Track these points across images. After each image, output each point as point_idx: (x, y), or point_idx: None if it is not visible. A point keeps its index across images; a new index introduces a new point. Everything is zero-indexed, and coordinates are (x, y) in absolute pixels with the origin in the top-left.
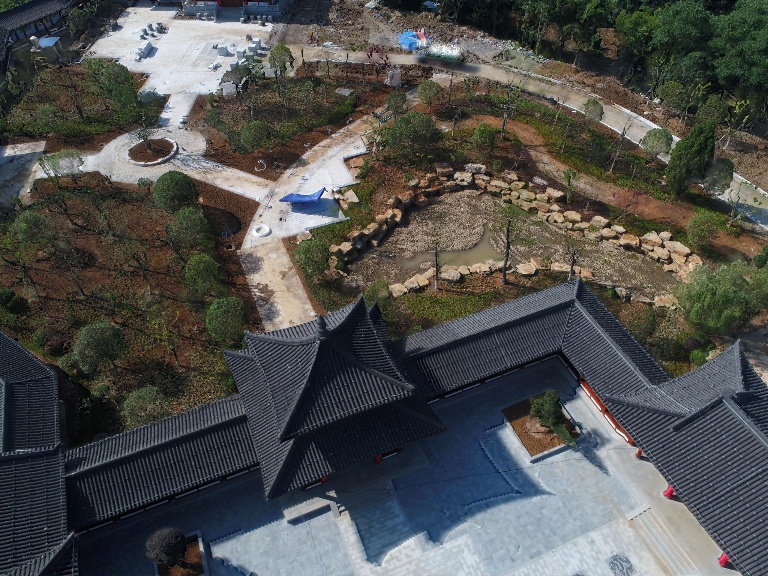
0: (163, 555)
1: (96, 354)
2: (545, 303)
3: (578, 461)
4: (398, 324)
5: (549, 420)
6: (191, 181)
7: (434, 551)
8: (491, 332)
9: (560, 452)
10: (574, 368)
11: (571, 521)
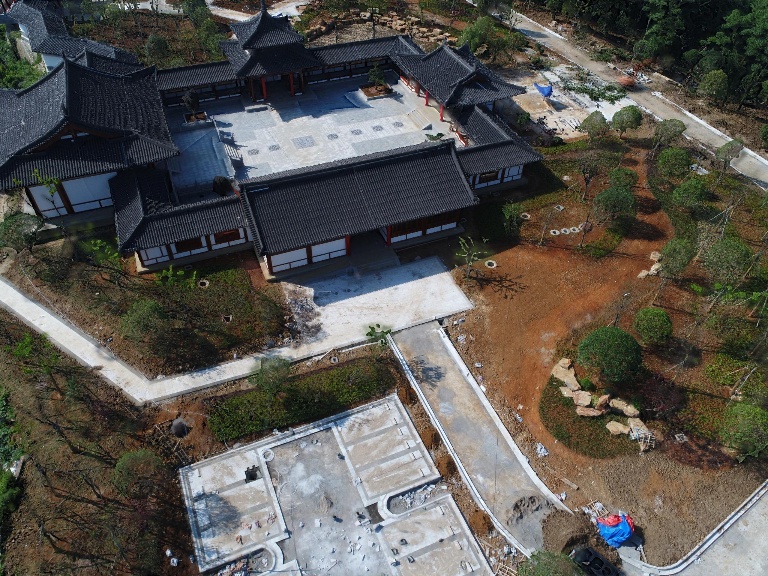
0: (190, 98)
1: (156, 47)
2: None
3: (391, 100)
4: None
5: (376, 79)
6: None
7: (314, 120)
8: (353, 44)
9: (383, 98)
10: (399, 72)
11: (380, 114)
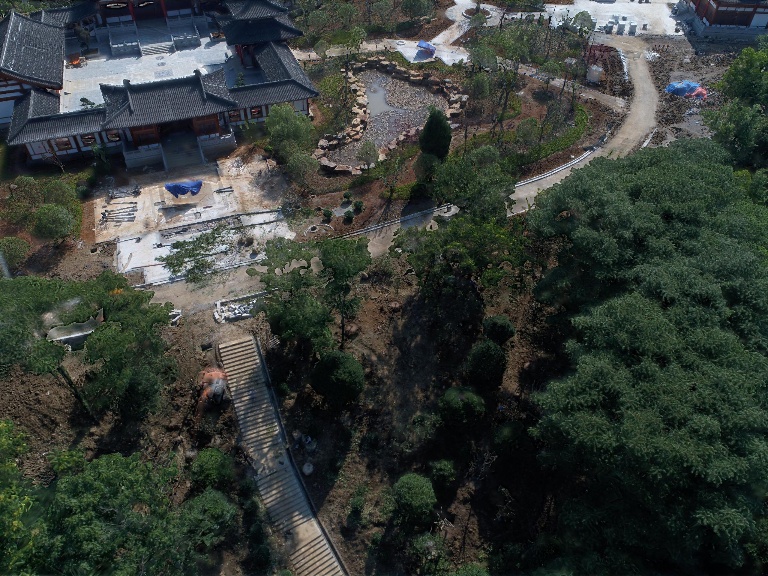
0: None
1: None
2: (298, 78)
3: None
4: (320, 72)
5: None
6: (418, 5)
7: None
8: None
9: None
10: None
11: None
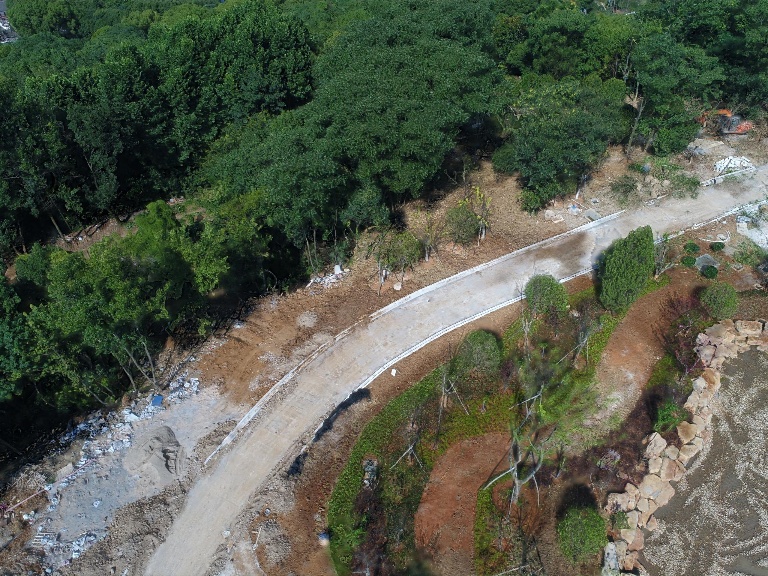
0: None
1: None
2: None
3: None
4: None
5: None
6: None
7: None
8: None
9: None
10: None
11: None
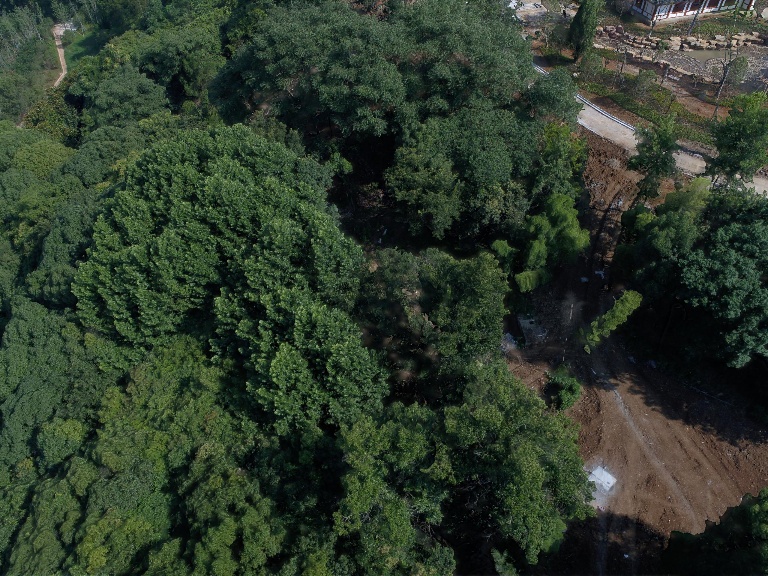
0: None
1: None
2: None
3: None
4: None
5: None
6: None
7: None
8: None
9: None
10: None
11: None
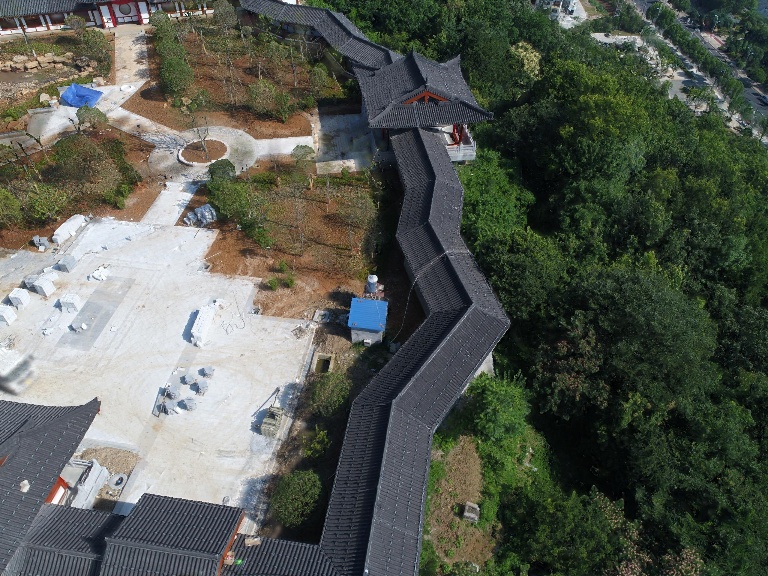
0: None
1: None
2: None
3: None
4: None
5: None
6: None
7: None
8: None
9: None
10: None
11: None
